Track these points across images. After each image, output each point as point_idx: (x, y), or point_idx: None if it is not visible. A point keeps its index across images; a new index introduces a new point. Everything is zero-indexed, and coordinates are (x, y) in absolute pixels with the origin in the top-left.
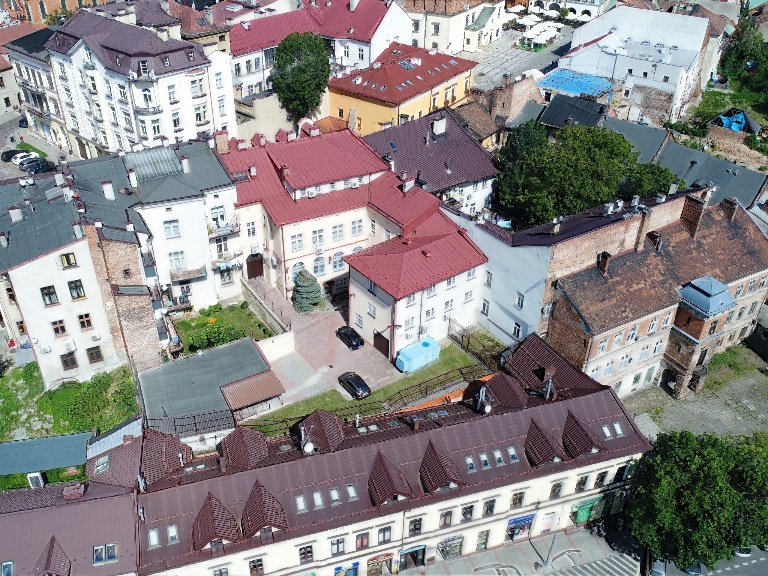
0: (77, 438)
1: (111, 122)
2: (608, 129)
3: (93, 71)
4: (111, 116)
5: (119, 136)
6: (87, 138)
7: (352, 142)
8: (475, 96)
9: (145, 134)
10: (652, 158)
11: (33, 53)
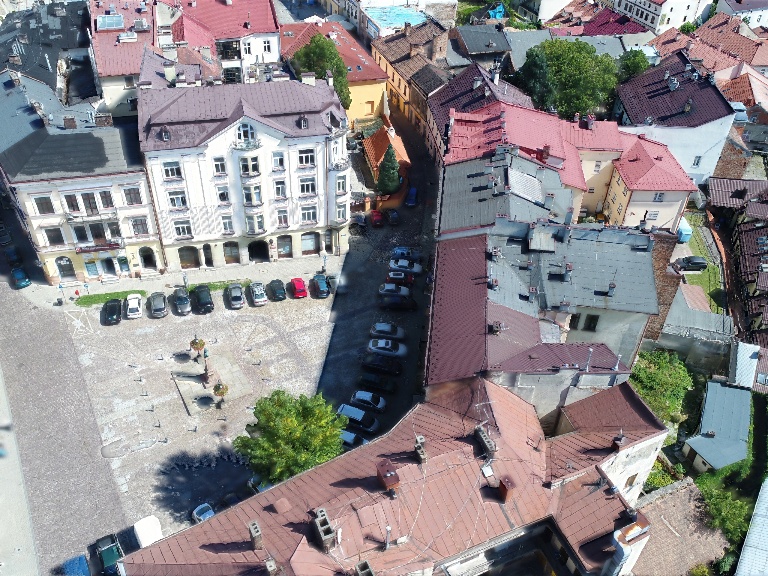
0: (715, 391)
1: (273, 200)
2: (513, 41)
3: (258, 150)
4: (274, 193)
5: (284, 211)
6: (210, 239)
7: (517, 111)
8: (417, 49)
9: (341, 190)
10: None
11: (96, 170)
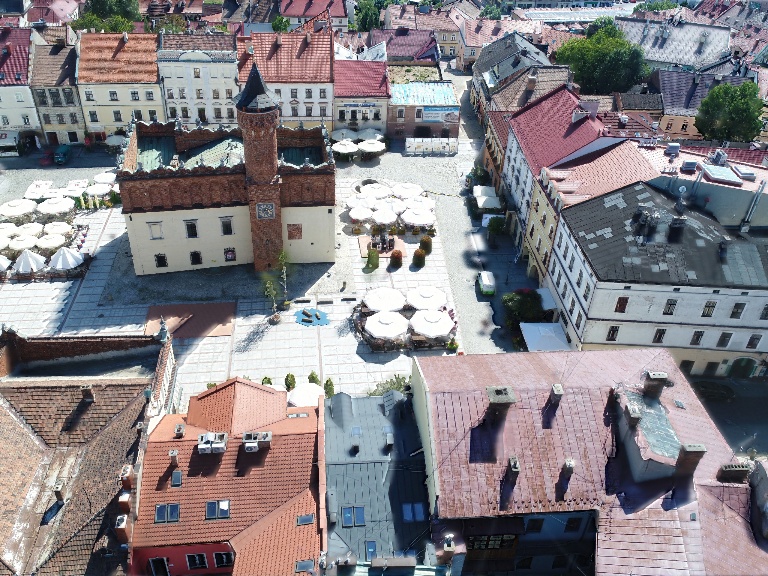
0: None
1: None
2: None
3: None
4: None
5: None
6: None
7: None
8: None
9: None
10: (534, 58)
11: None
